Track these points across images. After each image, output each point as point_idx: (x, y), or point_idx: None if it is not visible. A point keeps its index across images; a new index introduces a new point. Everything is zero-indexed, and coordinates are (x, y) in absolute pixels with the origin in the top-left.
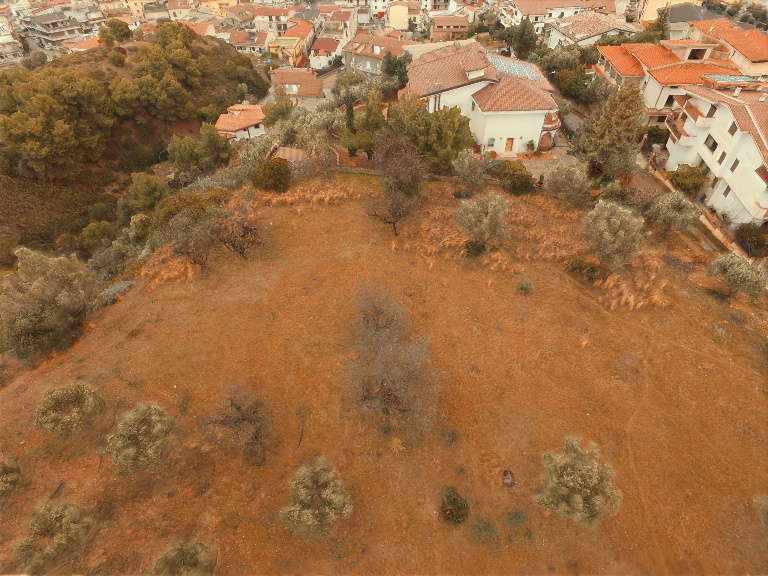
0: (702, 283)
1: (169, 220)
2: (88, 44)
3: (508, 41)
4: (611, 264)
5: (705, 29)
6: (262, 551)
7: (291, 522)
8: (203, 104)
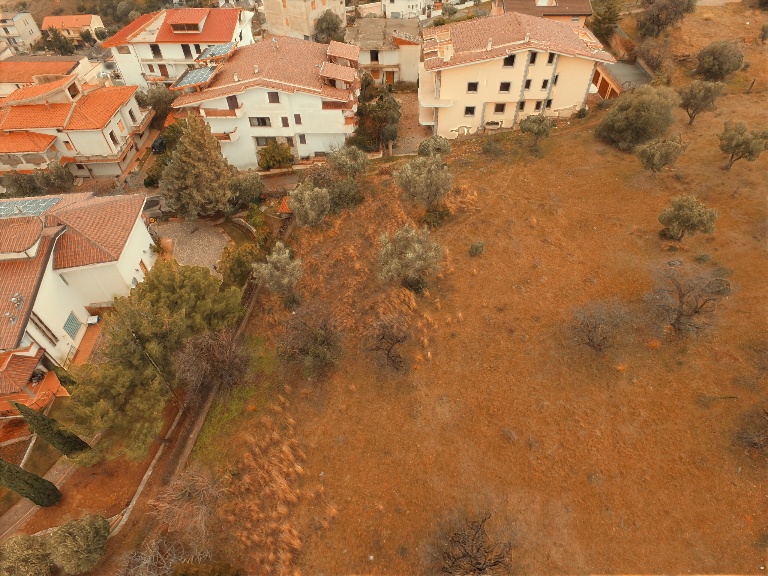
0: None
1: None
2: None
3: None
4: None
5: None
6: None
7: None
8: None
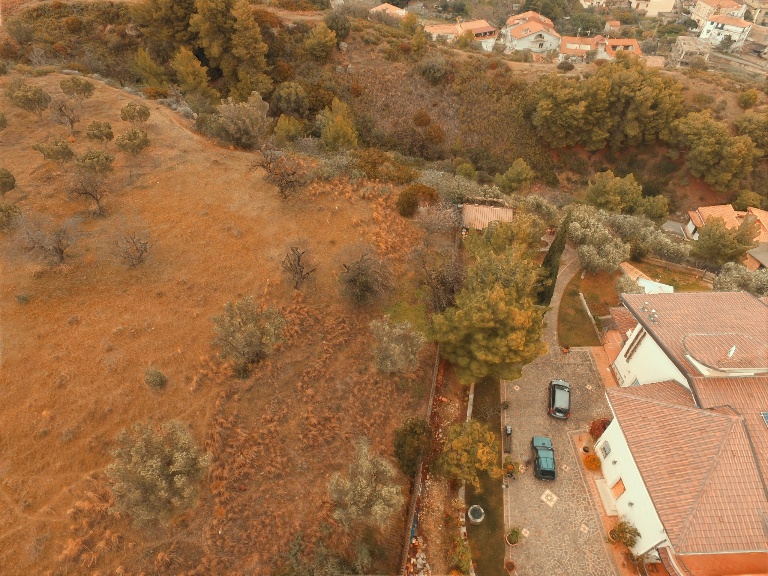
0: None
1: None
2: None
3: None
4: None
5: None
6: None
7: None
8: None
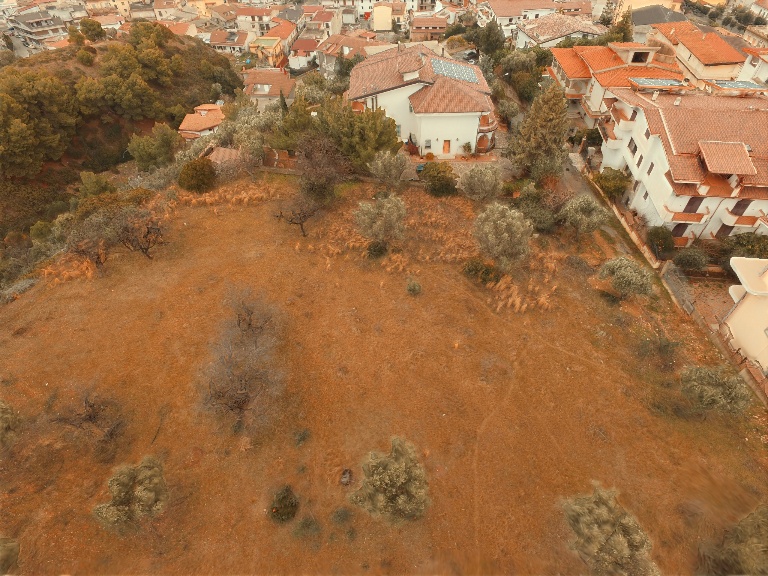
0: (599, 286)
1: (85, 219)
2: (64, 43)
3: (476, 43)
4: (502, 266)
5: (666, 32)
6: (86, 547)
7: (100, 518)
8: (174, 104)
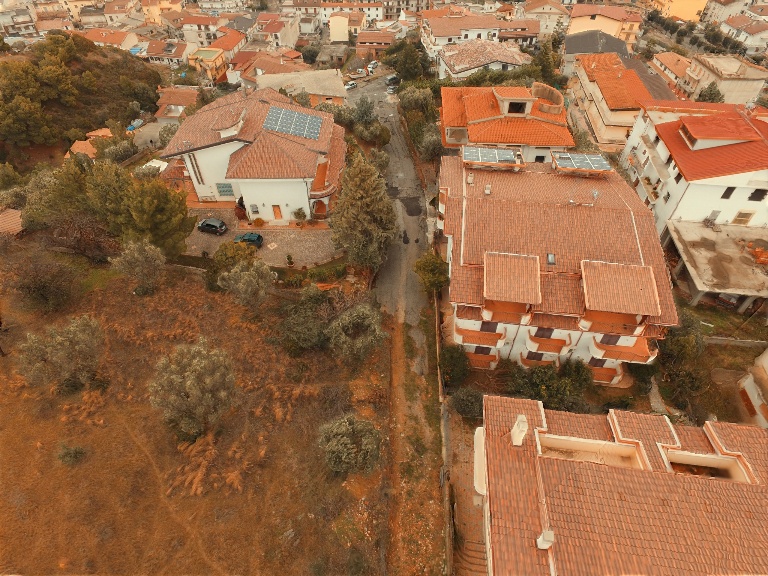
0: None
1: None
2: None
3: (395, 68)
4: None
5: (588, 65)
6: None
7: None
8: (77, 125)
